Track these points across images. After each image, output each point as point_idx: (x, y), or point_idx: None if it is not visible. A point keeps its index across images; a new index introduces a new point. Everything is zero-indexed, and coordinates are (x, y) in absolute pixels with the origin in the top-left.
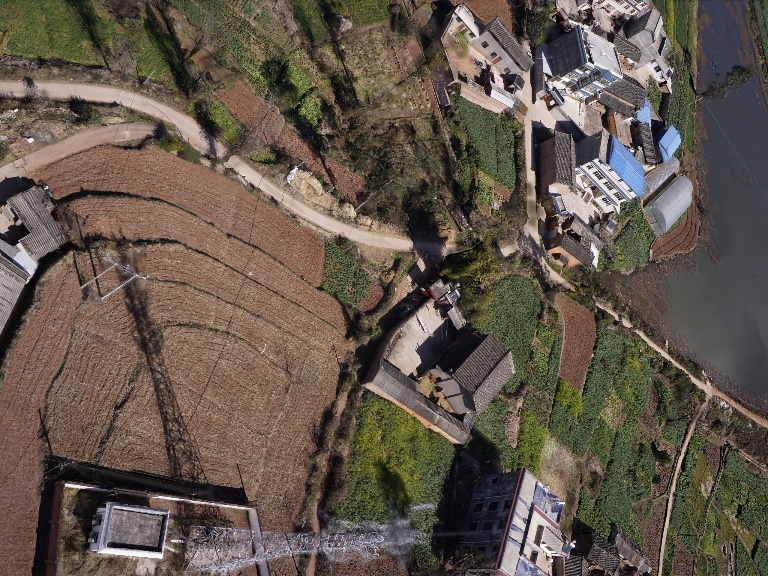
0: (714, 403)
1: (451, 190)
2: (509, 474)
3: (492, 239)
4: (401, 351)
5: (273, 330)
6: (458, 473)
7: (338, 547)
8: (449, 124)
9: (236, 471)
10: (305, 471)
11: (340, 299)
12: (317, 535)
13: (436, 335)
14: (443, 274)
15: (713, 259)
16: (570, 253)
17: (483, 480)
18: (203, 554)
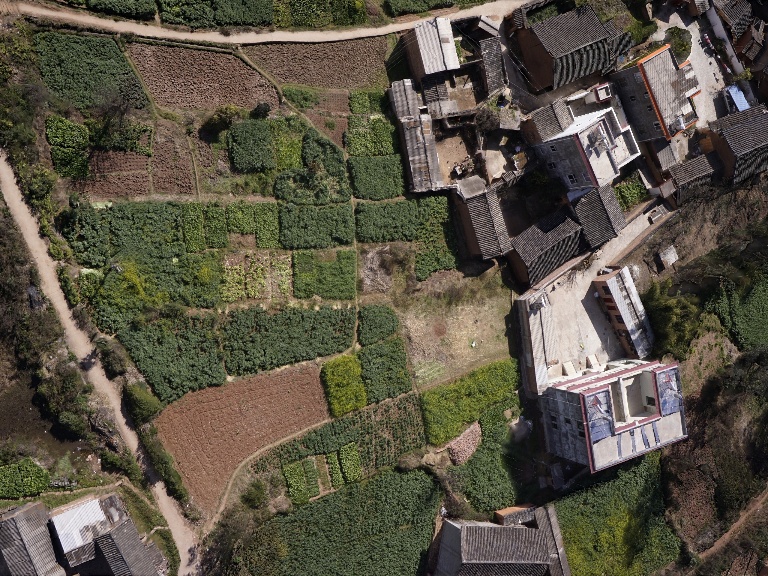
0: None
1: None
2: None
3: None
4: None
5: None
6: None
7: None
8: None
9: None
10: None
11: None
12: None
13: None
14: None
15: None
16: (155, 569)
17: None
18: None
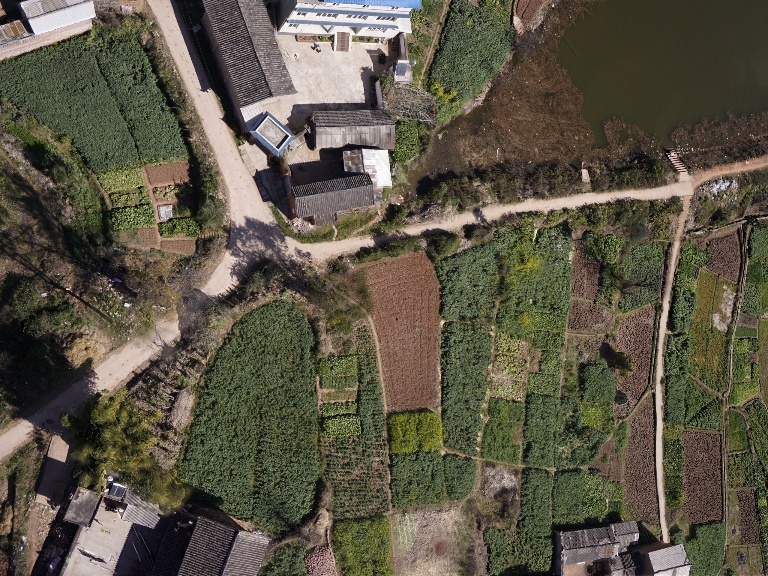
0: (700, 199)
1: (66, 256)
2: None
3: None
4: None
5: None
6: None
7: None
8: (6, 129)
9: None
10: None
11: None
12: None
13: (130, 548)
14: None
15: None
16: None
17: None
18: None
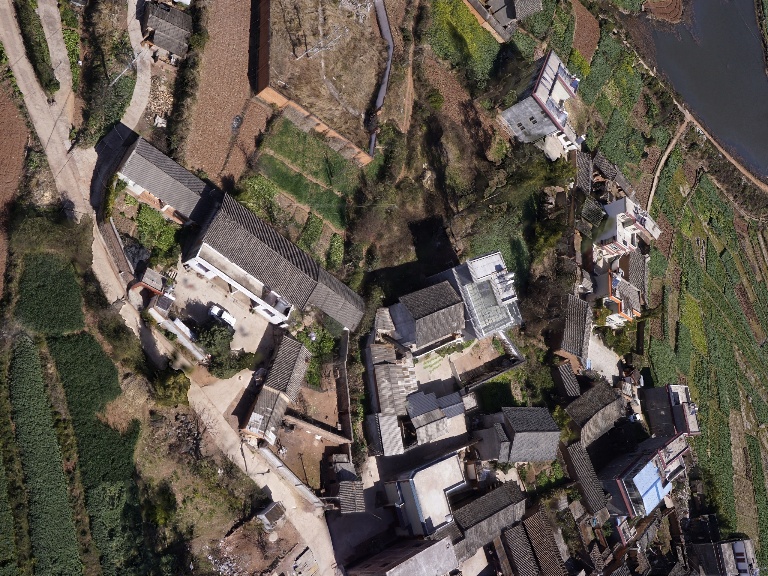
0: (691, 126)
1: None
2: (540, 58)
3: None
4: None
5: None
6: (502, 63)
7: None
8: None
9: None
10: (404, 1)
11: None
12: (413, 43)
13: None
14: None
15: (693, 38)
16: None
17: (520, 71)
18: None
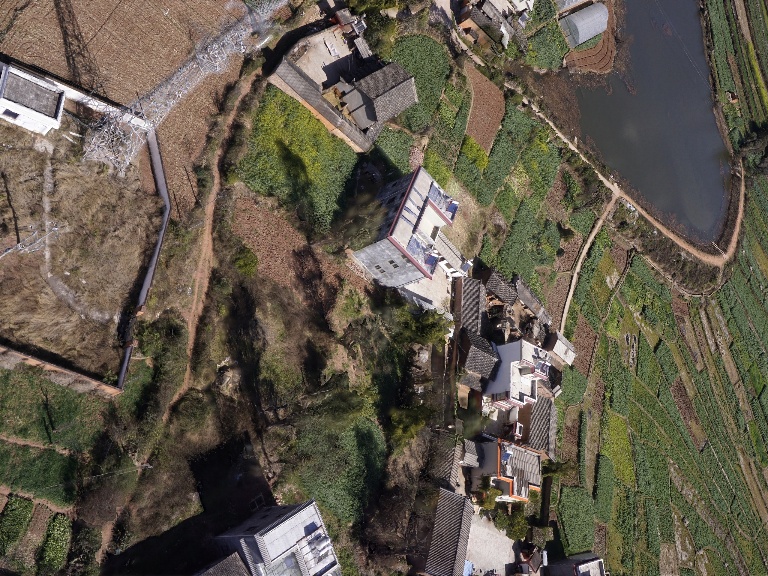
0: (621, 203)
1: None
2: (407, 175)
3: (404, 2)
4: (307, 64)
5: (177, 1)
6: (360, 179)
7: (211, 58)
8: None
9: (136, 97)
10: (206, 125)
11: (247, 4)
12: (217, 182)
13: (343, 62)
14: (351, 8)
15: (628, 87)
16: (480, 26)
17: (384, 188)
18: (101, 153)
